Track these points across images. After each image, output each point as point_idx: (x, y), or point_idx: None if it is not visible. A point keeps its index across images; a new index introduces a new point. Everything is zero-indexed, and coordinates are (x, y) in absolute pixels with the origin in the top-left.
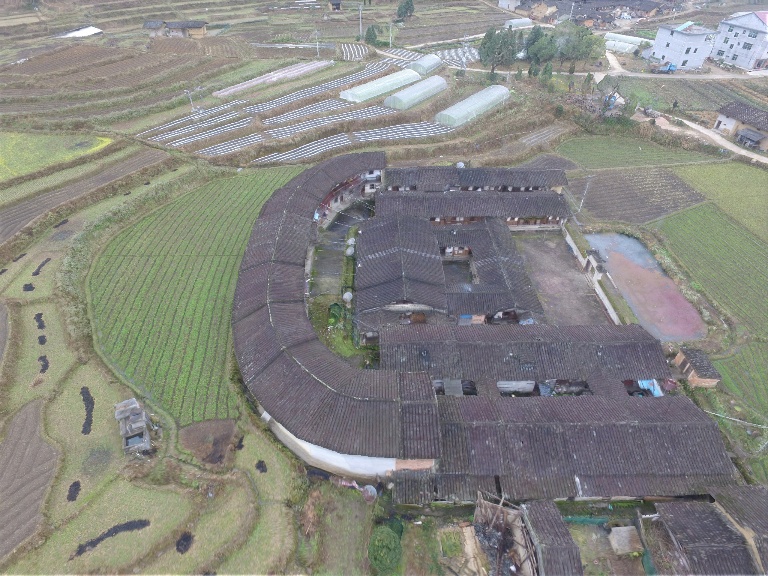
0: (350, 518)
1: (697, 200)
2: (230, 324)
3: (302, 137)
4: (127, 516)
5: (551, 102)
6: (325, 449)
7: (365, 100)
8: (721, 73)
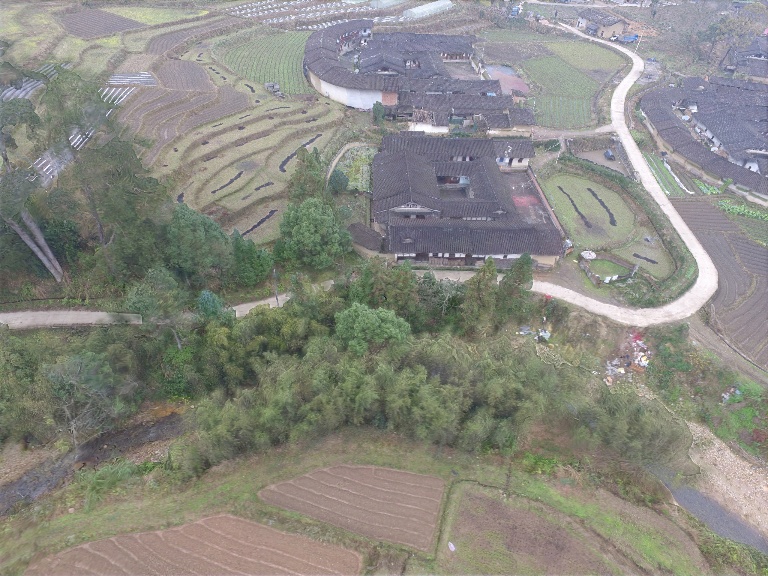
0: (364, 117)
1: (550, 55)
2: (302, 75)
3: (321, 18)
4: (281, 106)
5: (477, 9)
6: (353, 96)
7: (358, 3)
8: (601, 4)
